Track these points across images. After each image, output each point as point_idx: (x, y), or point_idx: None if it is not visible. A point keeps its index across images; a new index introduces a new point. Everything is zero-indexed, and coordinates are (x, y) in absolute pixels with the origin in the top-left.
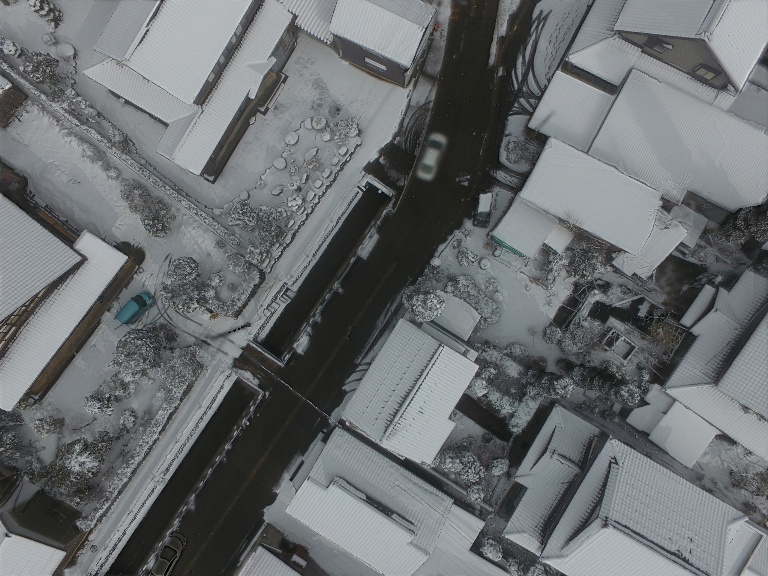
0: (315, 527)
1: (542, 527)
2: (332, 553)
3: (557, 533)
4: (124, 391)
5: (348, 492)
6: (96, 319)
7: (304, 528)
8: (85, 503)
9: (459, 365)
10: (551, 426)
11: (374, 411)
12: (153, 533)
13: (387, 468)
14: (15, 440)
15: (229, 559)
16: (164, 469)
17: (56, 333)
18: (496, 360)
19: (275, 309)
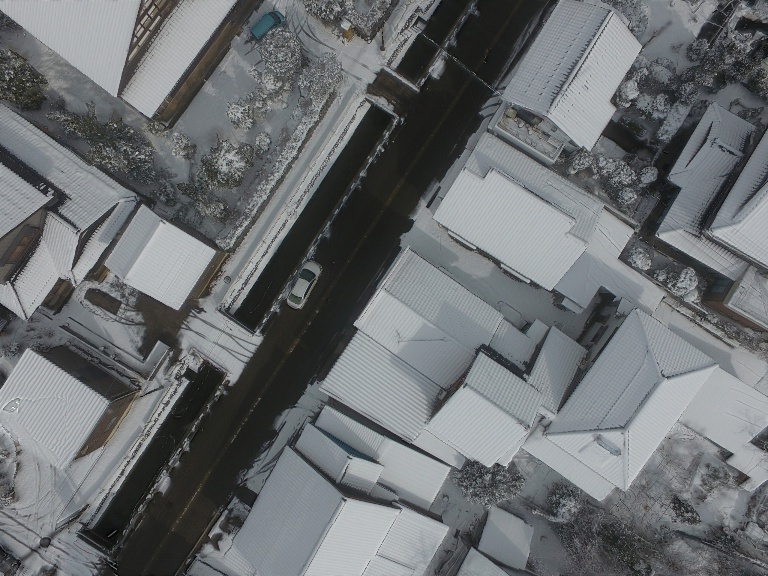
0: (464, 232)
1: (699, 221)
2: (471, 278)
3: (727, 204)
4: (263, 105)
5: (507, 178)
6: (226, 43)
7: (442, 254)
8: (219, 231)
9: (625, 39)
10: (707, 122)
11: (538, 87)
12: (282, 273)
13: (538, 170)
14: (151, 157)
15: (365, 287)
16: (296, 200)
17: (197, 33)
18: (646, 66)
19: (408, 36)
